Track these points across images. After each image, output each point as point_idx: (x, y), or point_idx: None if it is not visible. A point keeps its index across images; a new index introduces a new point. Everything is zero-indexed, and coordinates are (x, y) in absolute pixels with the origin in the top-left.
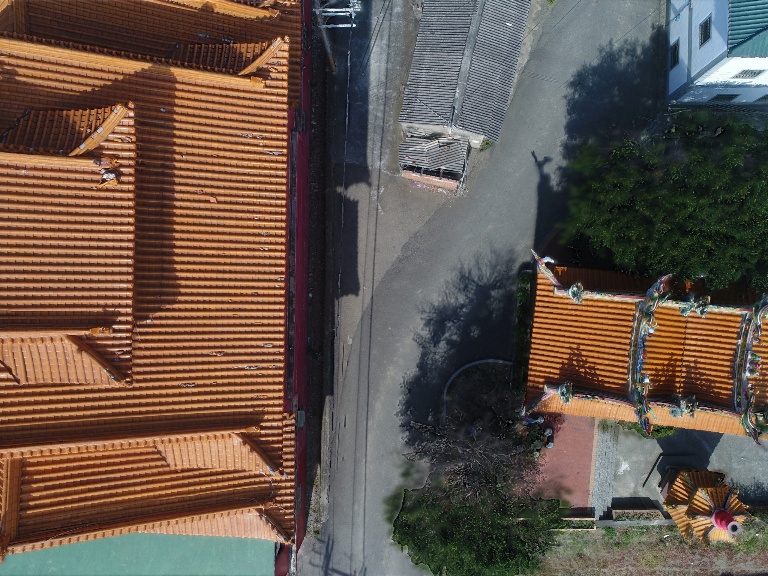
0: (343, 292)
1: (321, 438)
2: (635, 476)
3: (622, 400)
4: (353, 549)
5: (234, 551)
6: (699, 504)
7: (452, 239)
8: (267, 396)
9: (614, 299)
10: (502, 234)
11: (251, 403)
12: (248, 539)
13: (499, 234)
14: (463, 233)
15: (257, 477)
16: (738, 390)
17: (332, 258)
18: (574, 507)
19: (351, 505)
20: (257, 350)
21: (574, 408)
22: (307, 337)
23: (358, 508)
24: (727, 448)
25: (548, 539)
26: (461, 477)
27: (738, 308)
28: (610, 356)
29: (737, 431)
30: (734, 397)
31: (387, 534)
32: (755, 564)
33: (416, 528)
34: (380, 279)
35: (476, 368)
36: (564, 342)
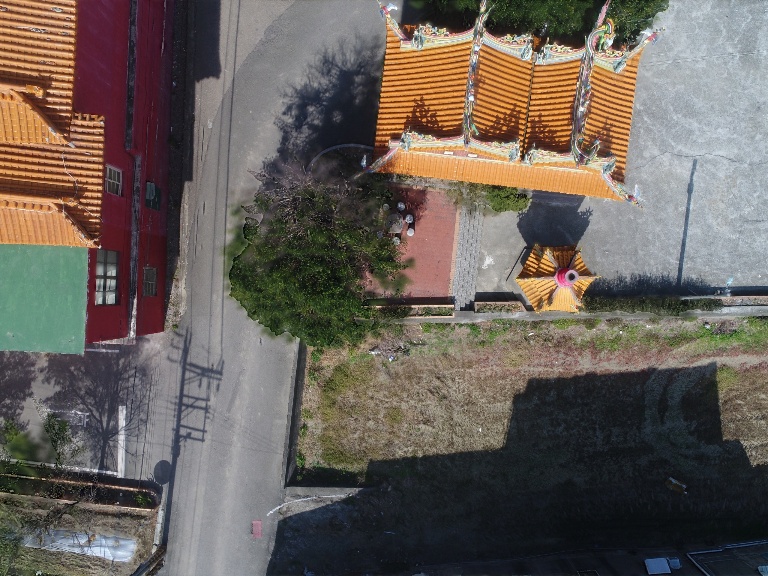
0: (204, 74)
1: (179, 226)
2: (499, 270)
3: (456, 136)
4: (211, 341)
5: (46, 272)
6: (545, 267)
7: (316, 23)
8: (56, 63)
9: (453, 41)
10: (368, 20)
11: (37, 68)
12: (61, 259)
13: (364, 20)
14: (328, 17)
15: (59, 174)
16: (574, 131)
17: (193, 40)
18: (434, 296)
19: (209, 295)
20: (45, 13)
21: (421, 168)
22: (170, 126)
23: (216, 298)
24: (591, 241)
25: (413, 338)
26: (289, 210)
27: (576, 49)
28: (449, 100)
29: (582, 190)
30: (571, 139)
31: (245, 325)
32: (619, 363)
33: (246, 269)
34: (242, 62)
35: (337, 153)
36: (409, 96)
